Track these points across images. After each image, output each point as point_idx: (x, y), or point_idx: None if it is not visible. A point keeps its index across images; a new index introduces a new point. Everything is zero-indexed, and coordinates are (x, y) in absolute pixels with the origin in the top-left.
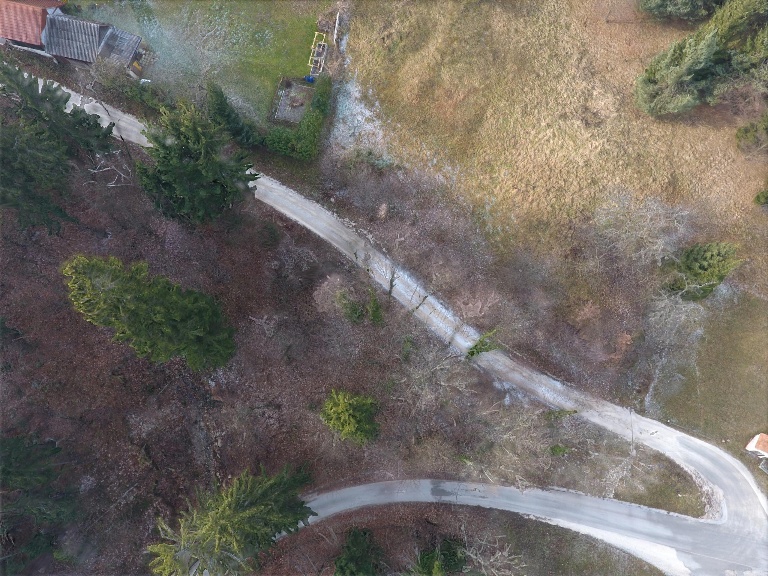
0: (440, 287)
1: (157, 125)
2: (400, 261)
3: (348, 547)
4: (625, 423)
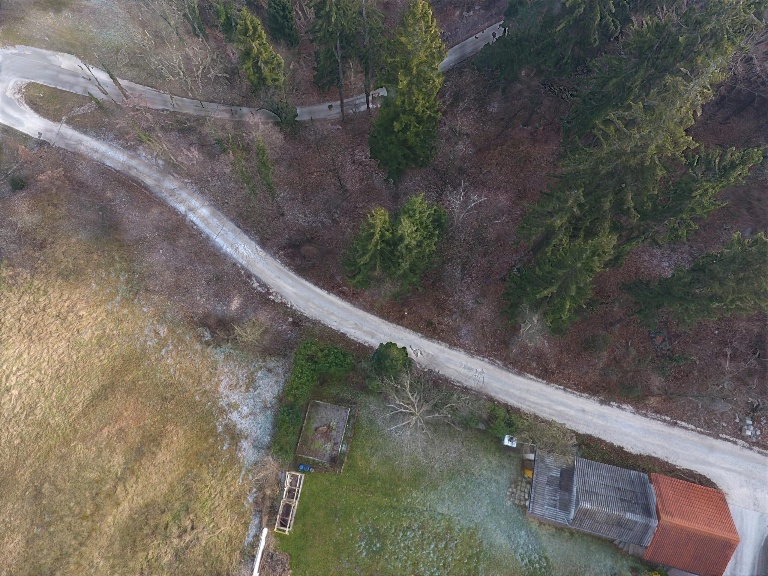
0: (193, 237)
1: (411, 212)
2: (195, 148)
3: (290, 50)
4: (62, 136)
